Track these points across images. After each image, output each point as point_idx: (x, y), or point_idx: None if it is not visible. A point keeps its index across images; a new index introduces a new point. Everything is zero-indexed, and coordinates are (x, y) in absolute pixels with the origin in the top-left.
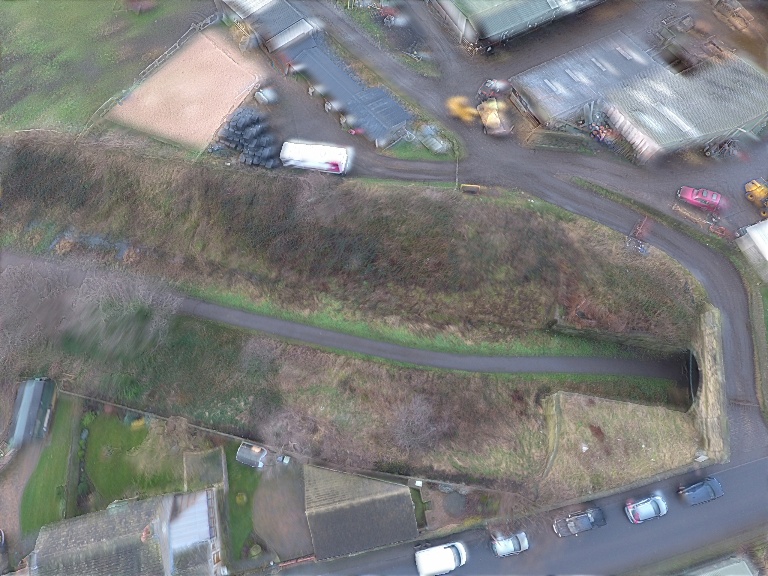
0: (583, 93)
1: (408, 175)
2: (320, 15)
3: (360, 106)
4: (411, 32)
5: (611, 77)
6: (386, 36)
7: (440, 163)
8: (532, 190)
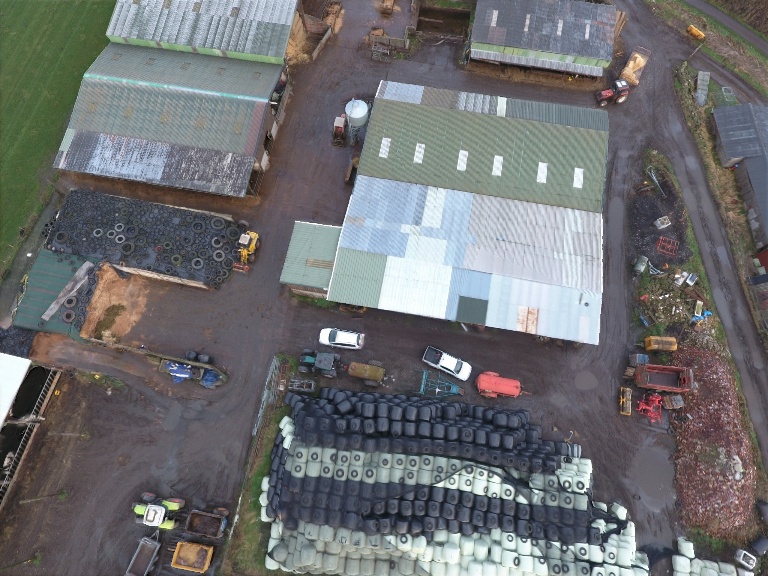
0: (569, 8)
1: (735, 80)
2: (730, 302)
3: (764, 141)
4: (634, 208)
5: (531, 5)
6: (670, 216)
7: (701, 70)
8: (642, 8)
